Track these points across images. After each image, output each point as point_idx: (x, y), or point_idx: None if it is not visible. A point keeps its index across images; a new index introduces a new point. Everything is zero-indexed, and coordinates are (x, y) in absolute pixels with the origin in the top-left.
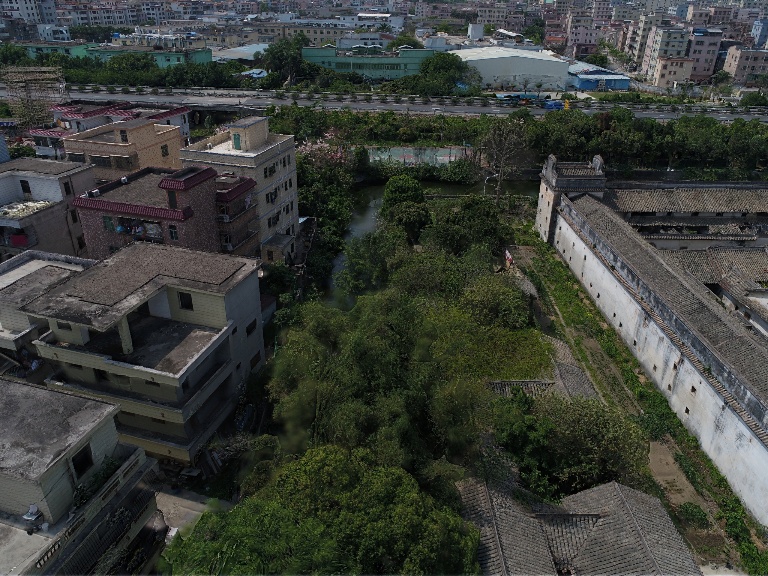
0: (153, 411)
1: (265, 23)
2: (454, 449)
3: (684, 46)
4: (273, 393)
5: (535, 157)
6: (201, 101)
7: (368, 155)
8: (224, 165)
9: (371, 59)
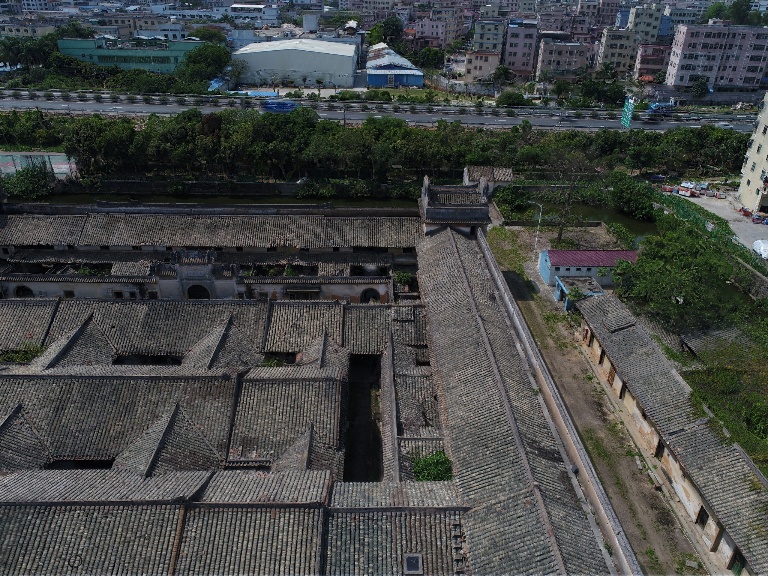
0: None
1: None
2: None
3: (499, 39)
4: None
5: (144, 166)
6: None
7: None
8: None
9: (136, 52)
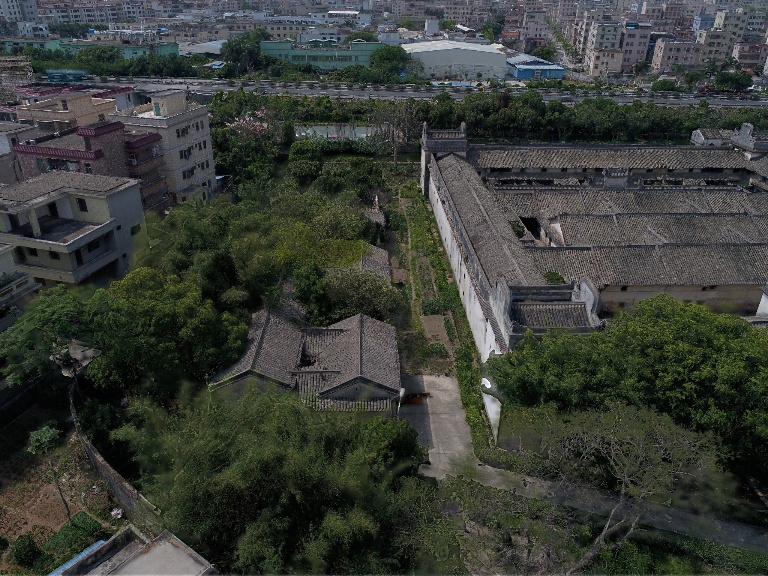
0: (54, 275)
1: (238, 20)
2: (254, 293)
3: (617, 39)
4: None
5: None
6: (158, 88)
7: (294, 130)
8: (143, 126)
9: (324, 52)
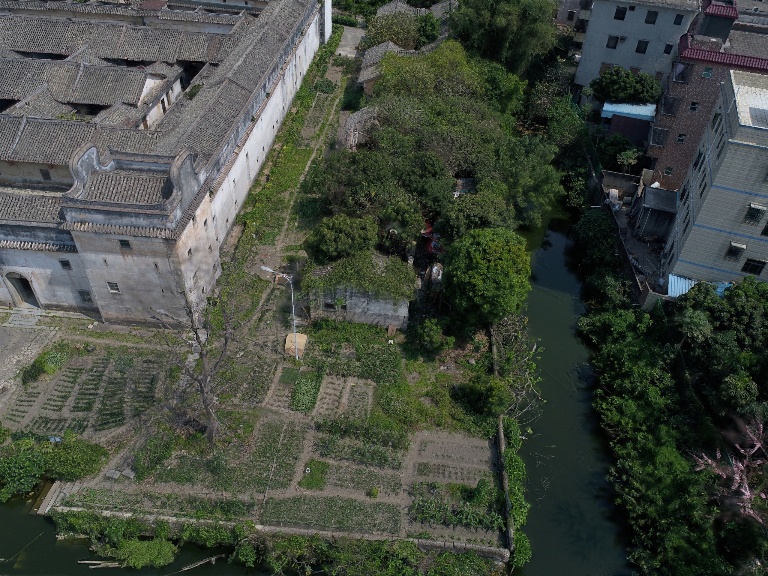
0: None
1: None
2: None
3: None
4: None
5: None
6: None
7: None
8: None
9: None
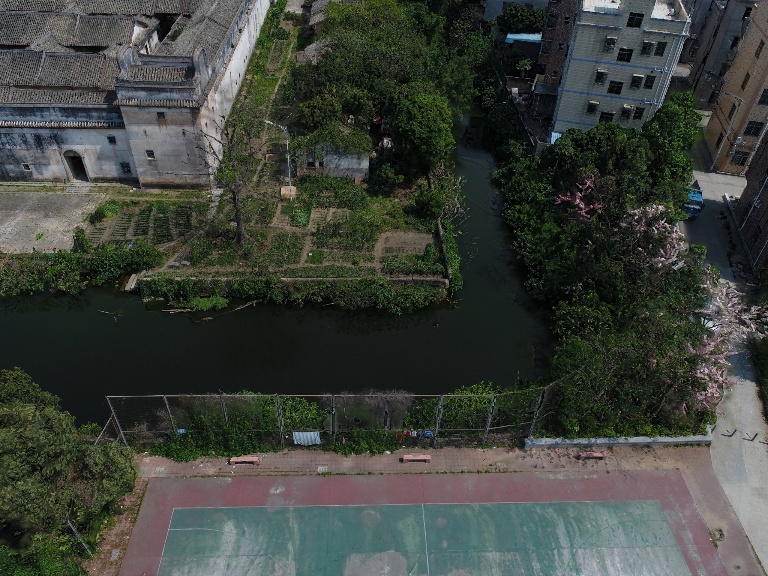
0: None
1: None
2: None
3: None
4: None
5: None
6: None
7: (555, 374)
8: None
9: None
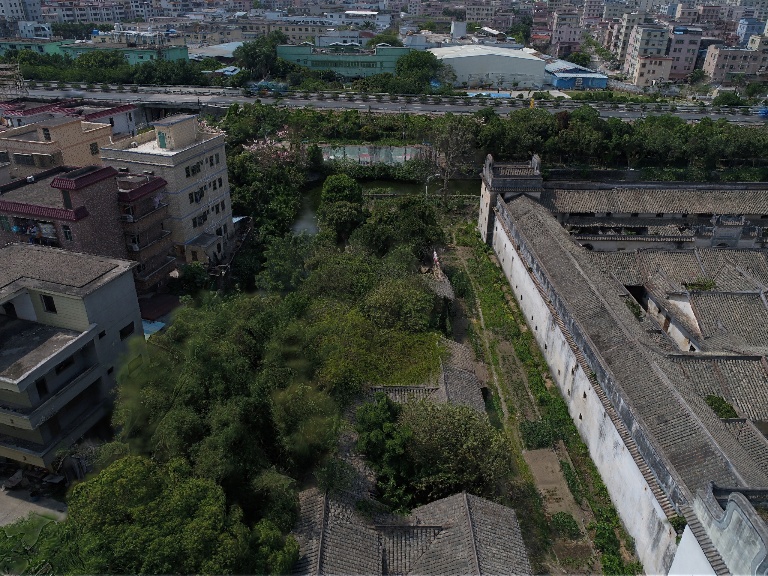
0: (2, 417)
1: (251, 20)
2: (302, 458)
3: (664, 45)
4: (150, 398)
5: (494, 156)
6: (165, 99)
7: (321, 154)
8: (143, 164)
9: (347, 57)
